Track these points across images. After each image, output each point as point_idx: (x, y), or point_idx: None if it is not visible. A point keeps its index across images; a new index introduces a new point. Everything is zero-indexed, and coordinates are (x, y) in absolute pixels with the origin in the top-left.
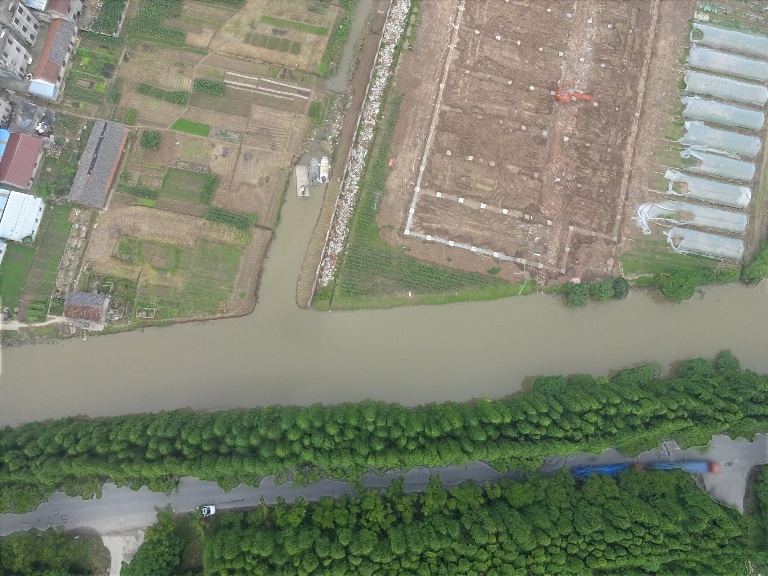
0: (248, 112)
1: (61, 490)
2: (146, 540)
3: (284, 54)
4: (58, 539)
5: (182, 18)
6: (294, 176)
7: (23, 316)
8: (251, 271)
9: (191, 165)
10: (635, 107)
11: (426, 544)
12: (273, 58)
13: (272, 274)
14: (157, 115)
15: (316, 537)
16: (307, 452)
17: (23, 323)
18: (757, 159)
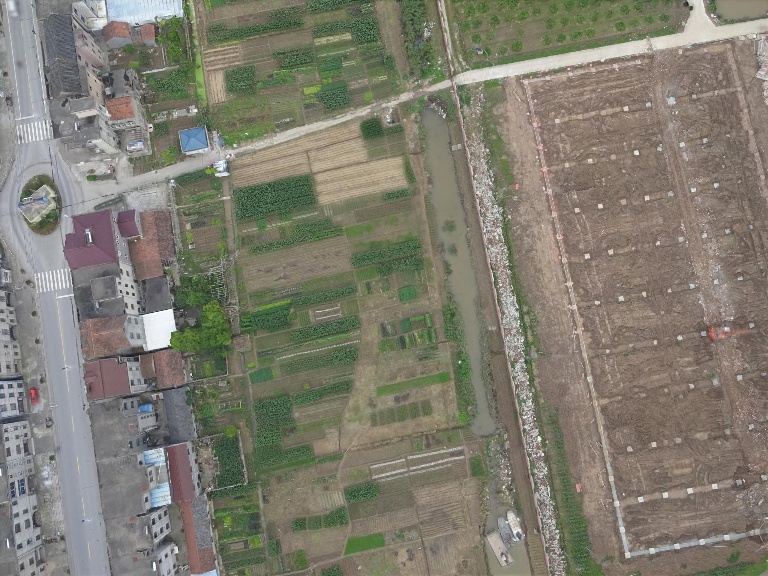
0: (412, 500)
1: None
2: None
3: (418, 420)
4: None
5: (300, 429)
6: (488, 545)
7: None
8: None
9: None
10: None
11: None
12: (409, 430)
13: None
14: (325, 546)
15: None
16: None
17: None
18: None
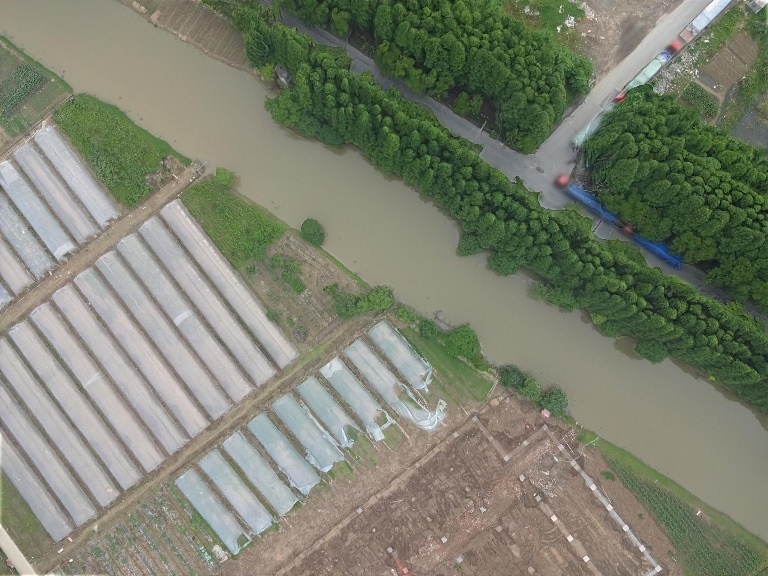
0: None
1: None
2: None
3: None
4: None
5: None
6: None
7: None
8: None
9: None
10: (356, 519)
11: None
12: None
13: None
14: None
15: None
16: None
17: None
18: (286, 388)
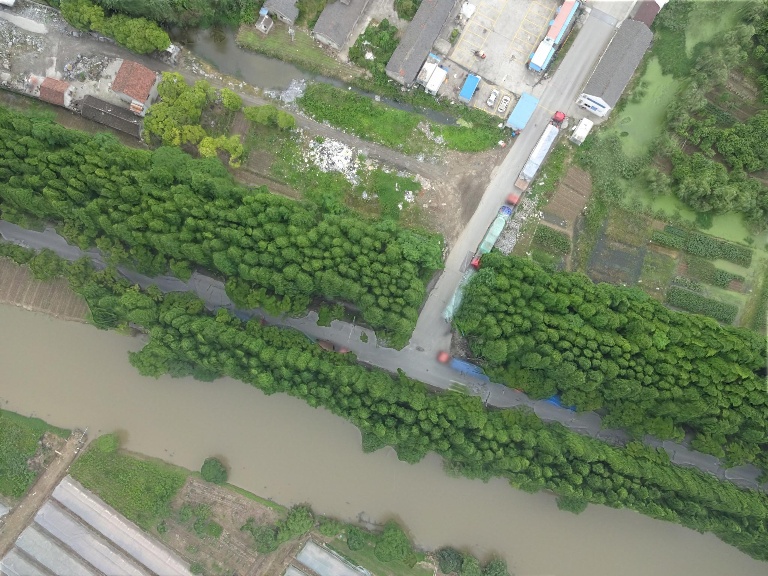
0: None
1: None
2: None
3: None
4: None
5: None
6: None
7: None
8: None
9: None
10: None
11: None
12: None
13: None
14: None
15: None
16: None
17: None
18: None
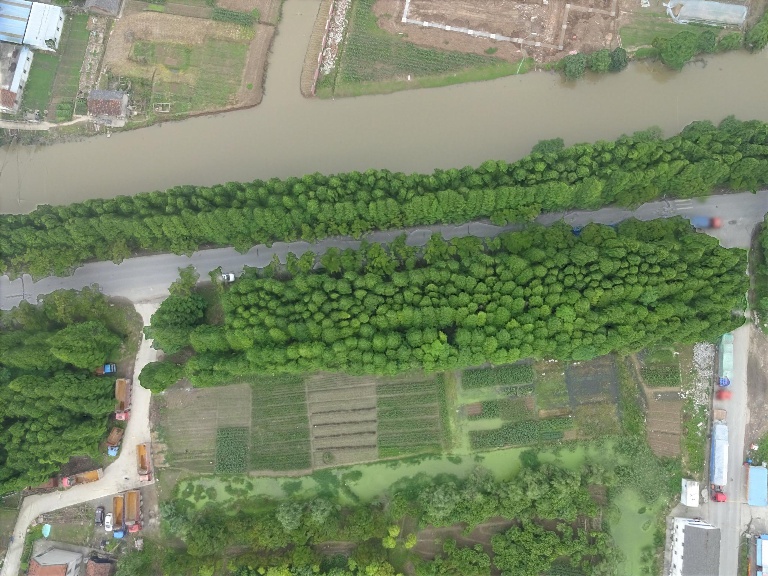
0: None
1: (94, 254)
2: (171, 291)
3: None
4: (94, 294)
5: None
6: None
7: (52, 117)
8: (257, 64)
9: None
10: None
11: (427, 277)
12: None
13: (277, 67)
14: None
15: (324, 279)
16: (312, 201)
17: (53, 123)
18: None
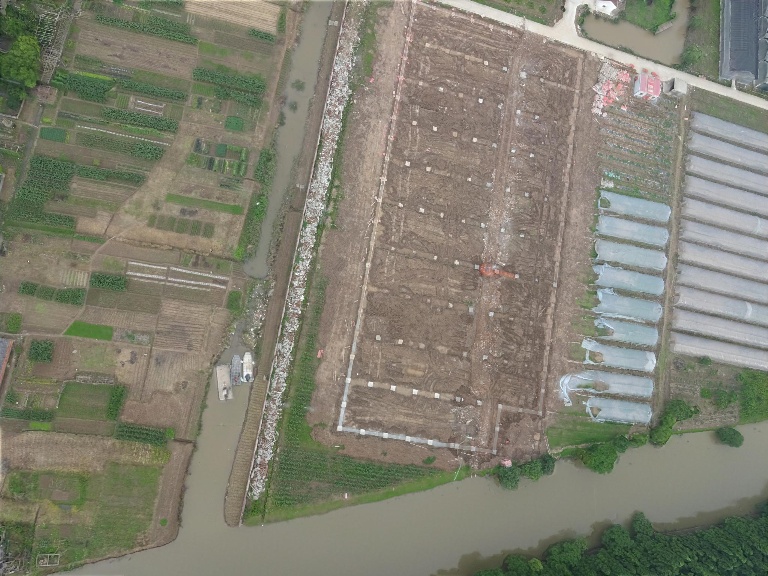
0: (158, 308)
1: None
2: None
3: (195, 238)
4: None
5: (71, 199)
6: (214, 377)
7: None
8: (172, 494)
9: (93, 377)
10: (553, 277)
11: None
12: (183, 243)
13: (196, 492)
14: (47, 319)
15: None
16: None
17: None
18: (659, 322)
